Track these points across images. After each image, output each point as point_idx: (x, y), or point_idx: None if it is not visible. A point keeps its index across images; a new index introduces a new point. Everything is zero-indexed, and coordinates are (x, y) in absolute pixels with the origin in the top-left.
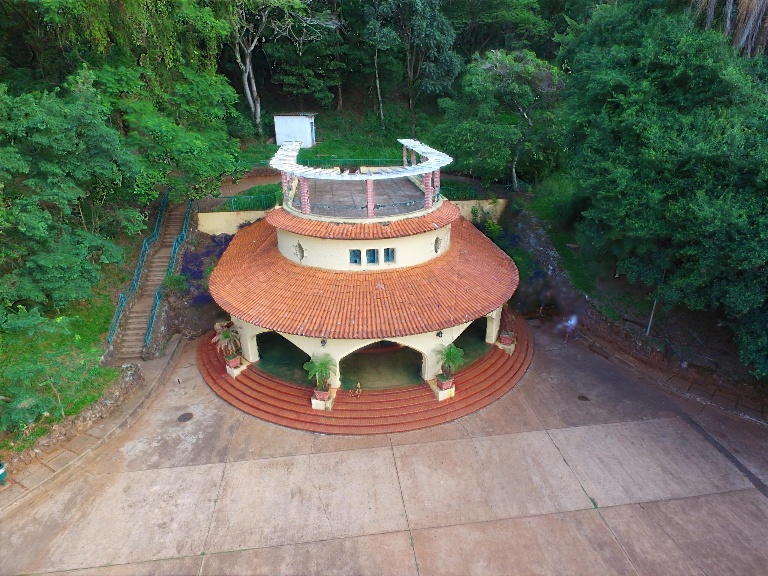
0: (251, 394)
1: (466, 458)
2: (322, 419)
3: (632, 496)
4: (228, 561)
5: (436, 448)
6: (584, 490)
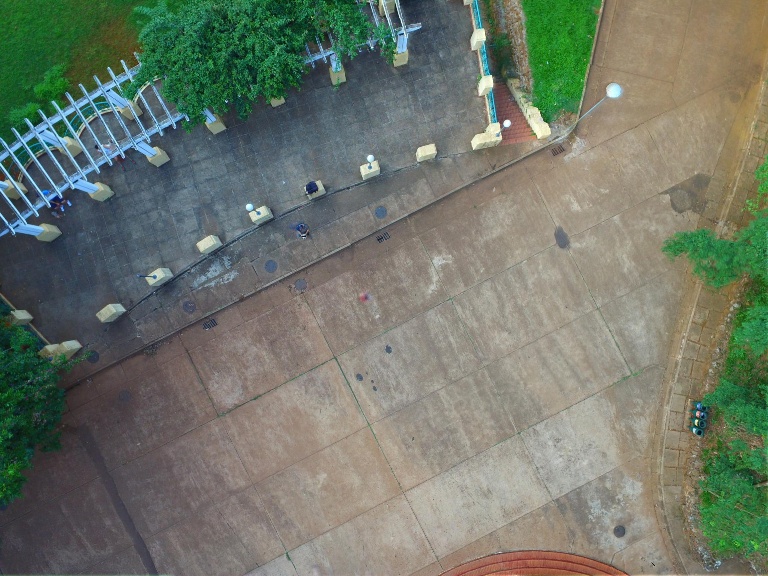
0: (581, 575)
1: (379, 568)
2: (504, 567)
3: (262, 572)
4: (502, 435)
5: (404, 570)
6: (294, 566)
